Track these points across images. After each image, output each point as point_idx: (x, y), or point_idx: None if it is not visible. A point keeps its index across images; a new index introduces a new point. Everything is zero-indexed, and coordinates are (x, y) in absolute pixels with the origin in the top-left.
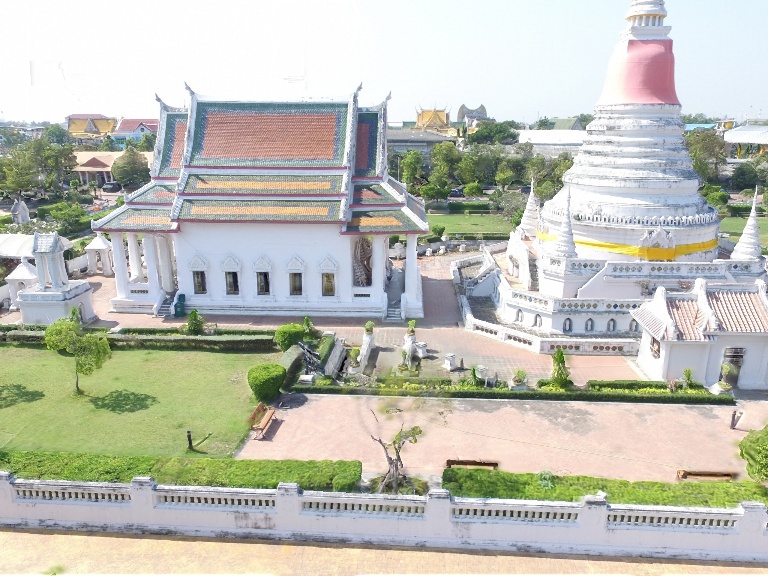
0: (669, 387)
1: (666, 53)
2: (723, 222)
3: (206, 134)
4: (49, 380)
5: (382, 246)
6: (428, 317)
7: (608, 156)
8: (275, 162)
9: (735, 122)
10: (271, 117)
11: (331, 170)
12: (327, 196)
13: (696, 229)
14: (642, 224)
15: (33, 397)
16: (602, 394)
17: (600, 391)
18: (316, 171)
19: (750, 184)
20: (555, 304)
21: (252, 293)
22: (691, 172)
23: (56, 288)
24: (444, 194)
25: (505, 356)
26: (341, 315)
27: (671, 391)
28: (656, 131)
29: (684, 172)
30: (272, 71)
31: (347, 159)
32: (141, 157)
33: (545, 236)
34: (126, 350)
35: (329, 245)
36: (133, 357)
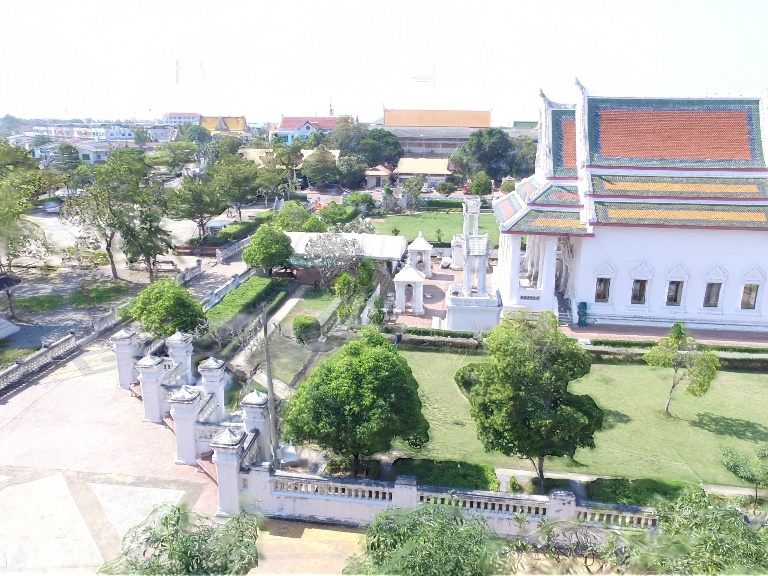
0: None
1: None
2: None
3: (601, 132)
4: (599, 397)
5: None
6: None
7: None
8: (686, 163)
9: None
10: (671, 114)
11: (752, 172)
12: (758, 200)
13: None
14: None
15: (619, 417)
16: None
17: None
18: (735, 173)
19: None
20: None
21: (659, 303)
22: None
23: (483, 293)
24: None
25: None
26: (762, 330)
27: None
28: None
29: None
30: (402, 70)
31: None
32: (330, 155)
33: None
34: (619, 364)
35: (758, 254)
36: (643, 373)
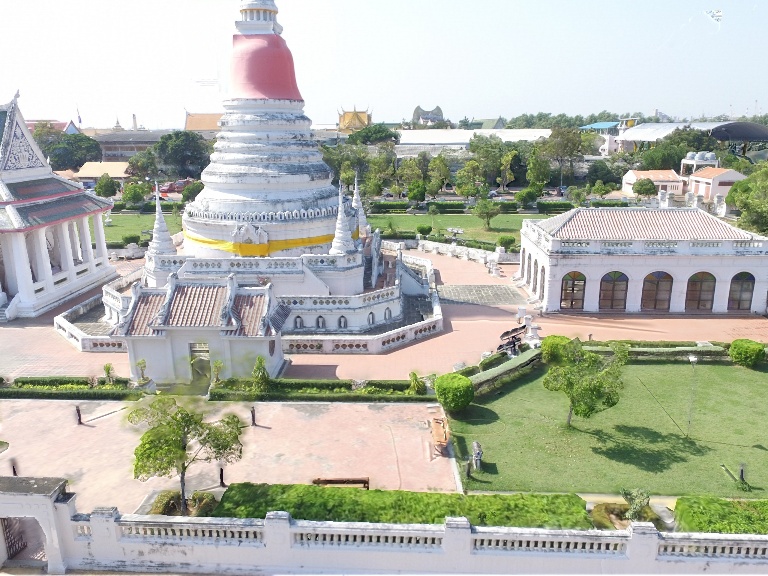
0: (90, 383)
1: (269, 48)
2: (521, 219)
3: None
4: None
5: None
6: (42, 316)
7: (221, 152)
8: None
9: (636, 120)
10: None
11: None
12: None
13: (292, 224)
14: (235, 220)
15: None
16: (11, 391)
17: (19, 388)
18: None
19: (603, 181)
20: (123, 301)
21: None
22: (304, 167)
23: None
24: None
25: (43, 354)
26: None
27: (91, 387)
28: (259, 126)
29: (292, 167)
30: (183, 74)
31: None
32: None
33: (184, 233)
34: None
35: None
36: None
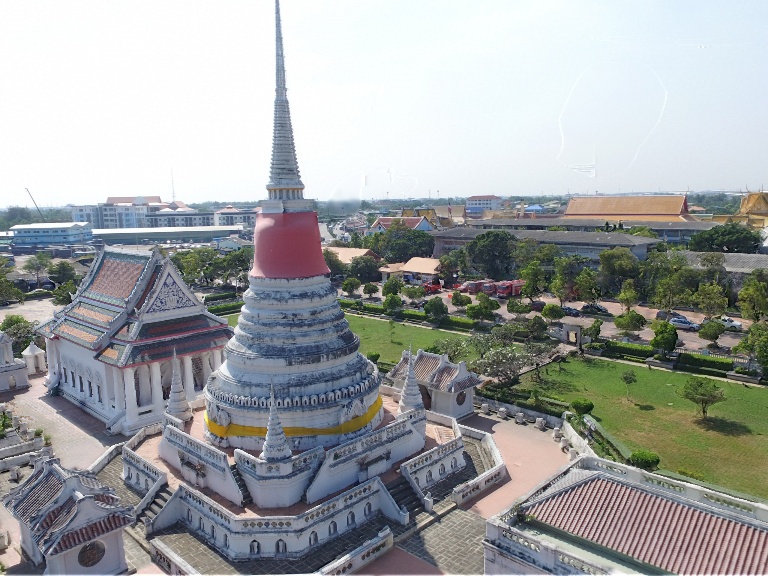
0: None
1: (274, 227)
2: None
3: None
4: None
5: (117, 372)
6: None
7: None
8: None
9: None
10: (123, 264)
11: None
12: None
13: (248, 412)
14: None
15: None
16: None
17: None
18: None
19: None
20: None
21: None
22: (286, 350)
23: (0, 365)
24: (485, 315)
25: None
26: (101, 419)
27: None
28: (255, 304)
29: (272, 349)
30: (560, 162)
31: (124, 301)
32: (334, 255)
33: None
34: None
35: (98, 365)
36: None
